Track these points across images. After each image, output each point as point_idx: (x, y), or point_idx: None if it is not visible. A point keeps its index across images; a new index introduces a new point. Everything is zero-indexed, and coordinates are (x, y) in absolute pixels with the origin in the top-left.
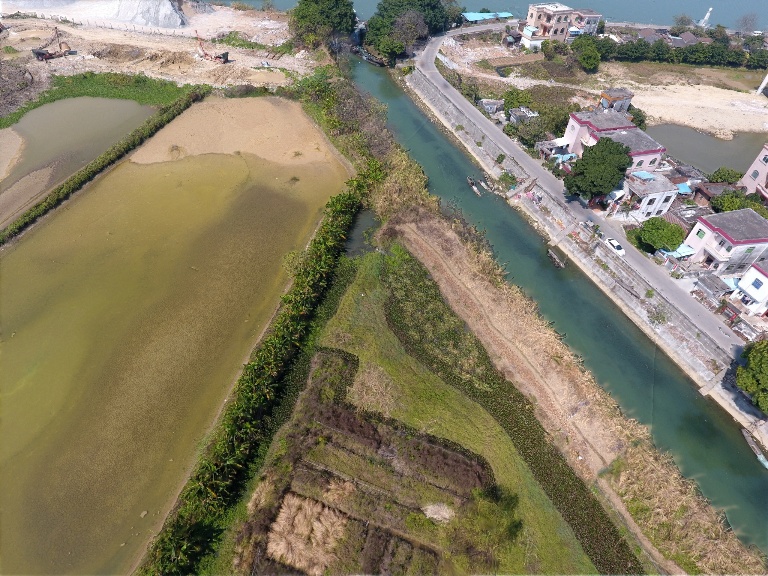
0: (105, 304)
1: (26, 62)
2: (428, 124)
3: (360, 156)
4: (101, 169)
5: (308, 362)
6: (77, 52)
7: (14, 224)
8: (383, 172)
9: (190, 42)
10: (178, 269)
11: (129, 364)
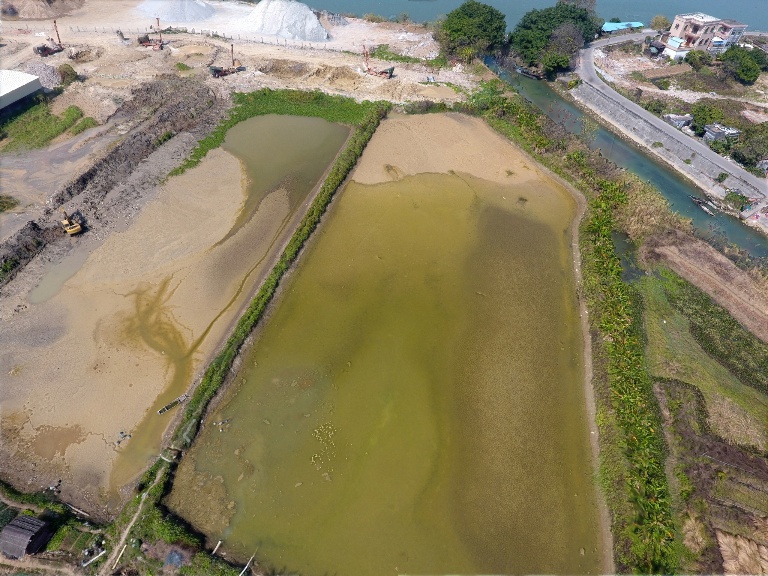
0: (417, 332)
1: (204, 79)
2: (618, 140)
3: (580, 175)
4: (335, 190)
5: (652, 392)
6: (245, 68)
7: (290, 249)
8: (624, 193)
9: (343, 56)
10: (466, 295)
11: (477, 394)
